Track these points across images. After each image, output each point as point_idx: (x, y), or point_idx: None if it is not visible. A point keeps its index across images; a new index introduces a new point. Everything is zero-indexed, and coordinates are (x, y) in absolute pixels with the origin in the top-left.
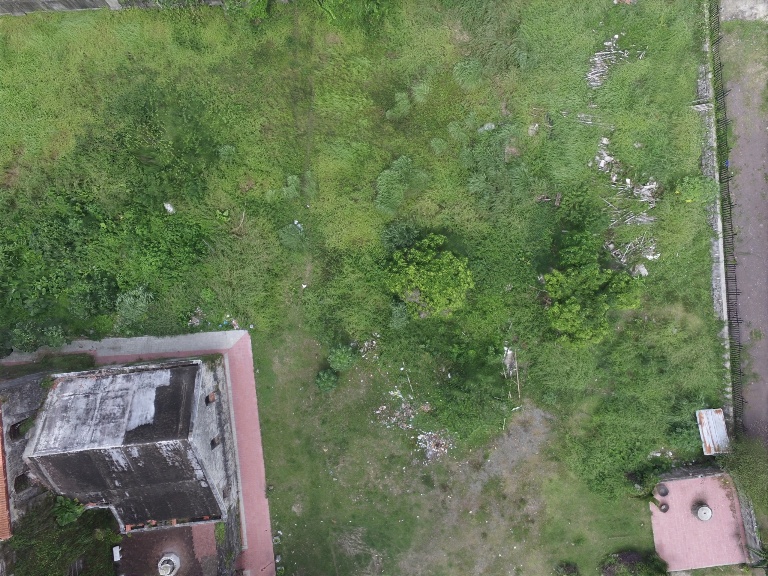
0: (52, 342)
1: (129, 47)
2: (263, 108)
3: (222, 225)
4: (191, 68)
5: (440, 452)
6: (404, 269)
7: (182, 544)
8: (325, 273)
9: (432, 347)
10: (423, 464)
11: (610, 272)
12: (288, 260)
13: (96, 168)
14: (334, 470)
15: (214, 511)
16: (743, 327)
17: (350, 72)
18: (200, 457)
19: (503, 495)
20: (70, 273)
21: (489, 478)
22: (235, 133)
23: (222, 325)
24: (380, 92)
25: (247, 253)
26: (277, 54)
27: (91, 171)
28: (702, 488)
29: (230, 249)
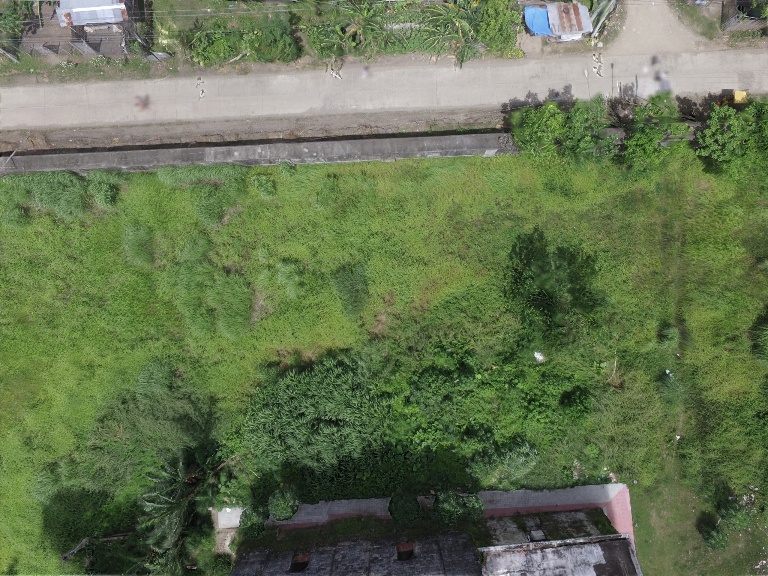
0: (473, 513)
1: (498, 193)
2: (632, 255)
3: (598, 376)
4: (557, 214)
5: None
6: None
7: None
8: (701, 425)
9: None
10: None
11: None
12: (662, 411)
13: (470, 318)
14: None
15: None
16: None
17: (722, 220)
18: None
19: None
20: (447, 426)
21: None
22: (607, 282)
23: (601, 478)
24: (750, 239)
25: (629, 407)
26: (646, 200)
27: (466, 321)
28: None
29: (612, 403)
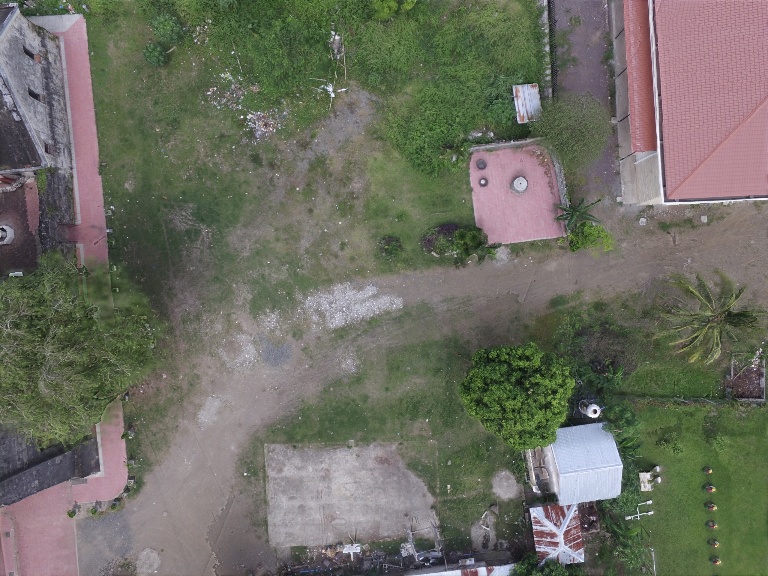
0: None
1: None
2: None
3: None
4: None
5: (269, 132)
6: None
7: (17, 217)
8: None
9: (261, 29)
10: (252, 143)
11: None
12: None
13: None
14: (165, 148)
15: (34, 157)
16: (563, 13)
17: None
18: (5, 75)
19: (329, 172)
20: None
21: (316, 156)
22: None
23: (58, 9)
24: None
25: None
26: None
27: None
28: (521, 165)
29: None
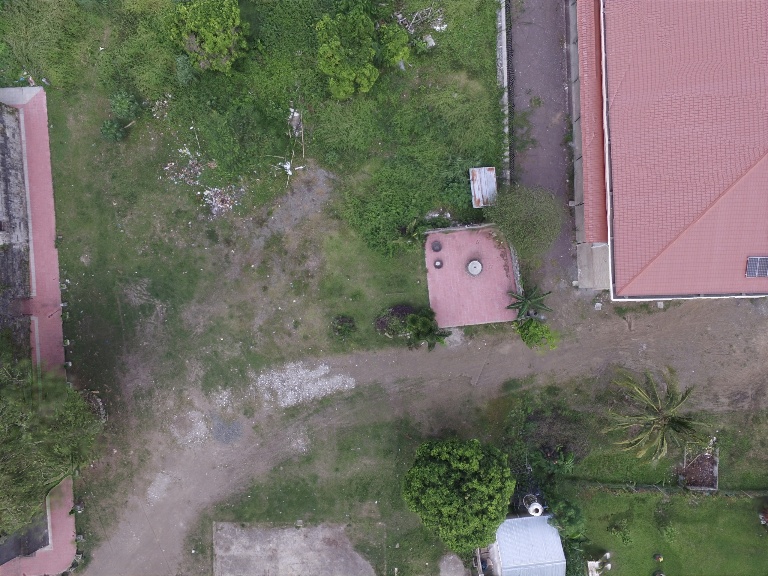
0: None
1: None
2: None
3: None
4: None
5: (225, 208)
6: (177, 10)
7: None
8: (121, 35)
9: (219, 106)
10: (208, 219)
11: (384, 26)
12: (86, 23)
13: None
14: (122, 222)
15: None
16: (523, 94)
17: None
18: None
19: (284, 250)
20: None
21: (271, 234)
22: None
23: (18, 81)
24: None
25: (43, 11)
26: None
27: None
28: (477, 247)
29: (26, 6)
